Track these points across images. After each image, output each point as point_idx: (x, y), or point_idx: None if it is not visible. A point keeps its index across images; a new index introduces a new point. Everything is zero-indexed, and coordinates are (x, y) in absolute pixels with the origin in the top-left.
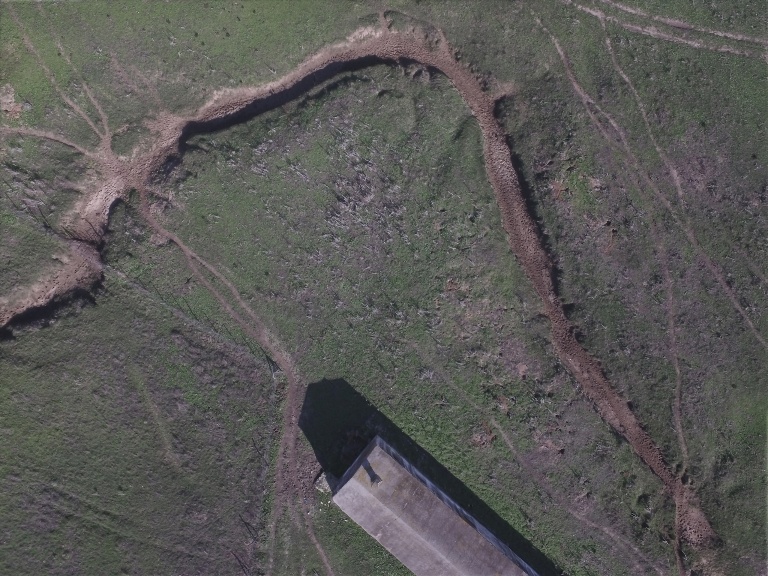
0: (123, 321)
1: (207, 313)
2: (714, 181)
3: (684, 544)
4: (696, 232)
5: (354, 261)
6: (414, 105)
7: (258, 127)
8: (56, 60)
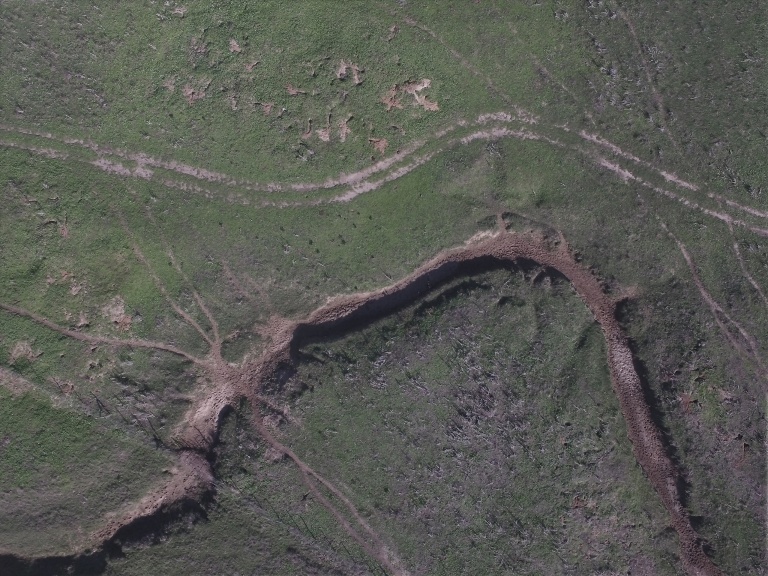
0: (237, 538)
1: (324, 531)
2: None
3: None
4: None
5: (476, 476)
6: (535, 312)
7: (374, 336)
8: (167, 269)
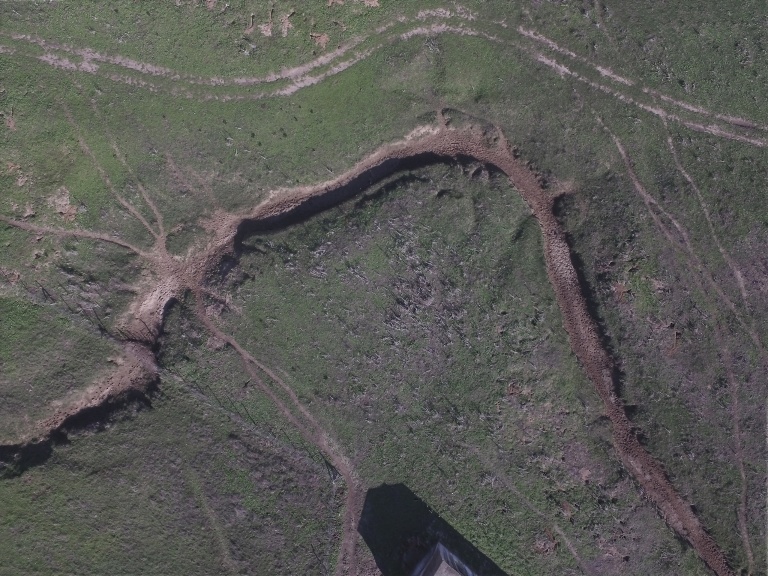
0: (180, 425)
1: (265, 417)
2: None
3: None
4: (761, 335)
5: (414, 364)
6: (473, 205)
7: (315, 228)
8: (111, 161)
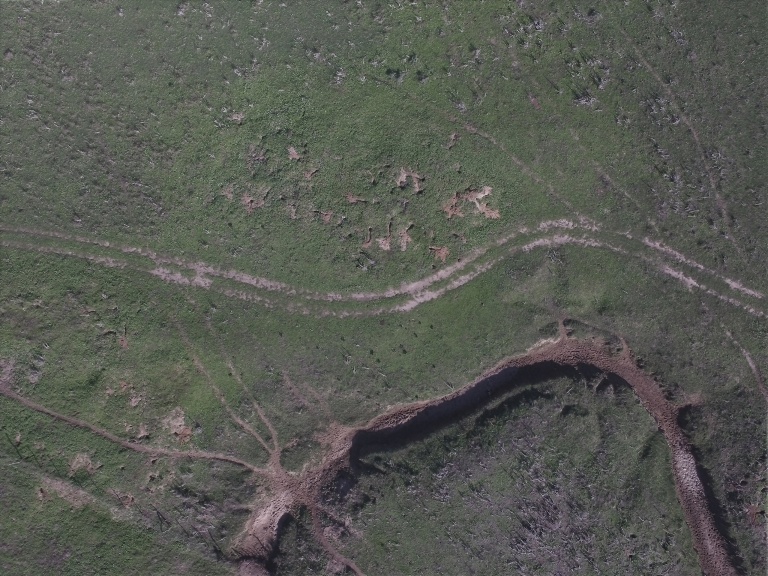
0: None
1: None
2: None
3: None
4: None
5: None
6: (598, 420)
7: (436, 446)
8: (227, 380)
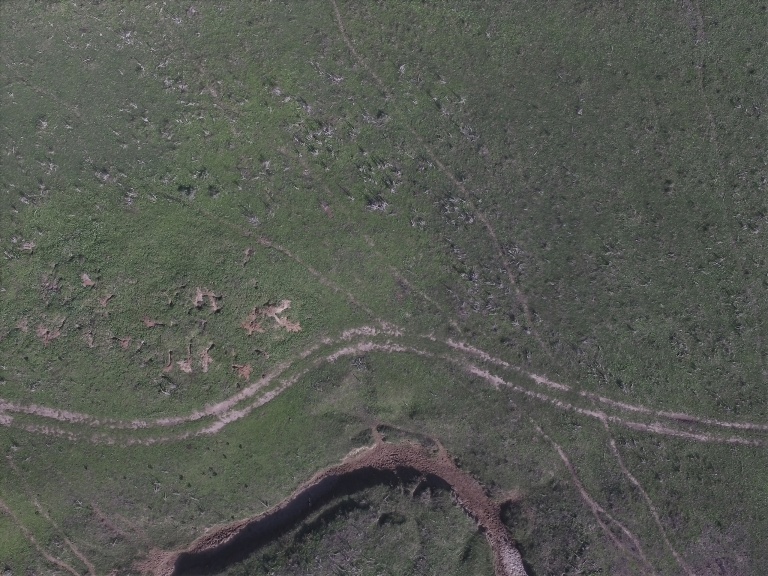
0: None
1: None
2: None
3: None
4: None
5: None
6: (417, 525)
7: (255, 566)
8: (34, 518)
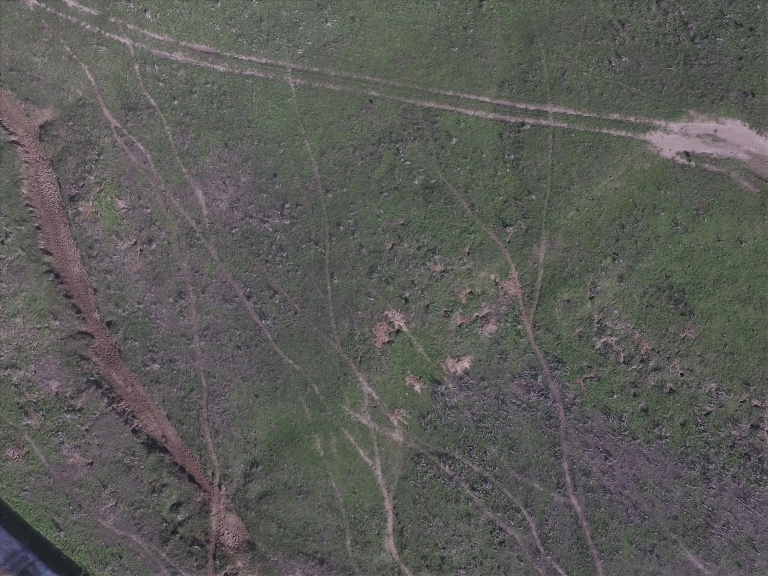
0: None
1: None
2: (238, 200)
3: (219, 548)
4: (219, 249)
5: None
6: None
7: None
8: None
